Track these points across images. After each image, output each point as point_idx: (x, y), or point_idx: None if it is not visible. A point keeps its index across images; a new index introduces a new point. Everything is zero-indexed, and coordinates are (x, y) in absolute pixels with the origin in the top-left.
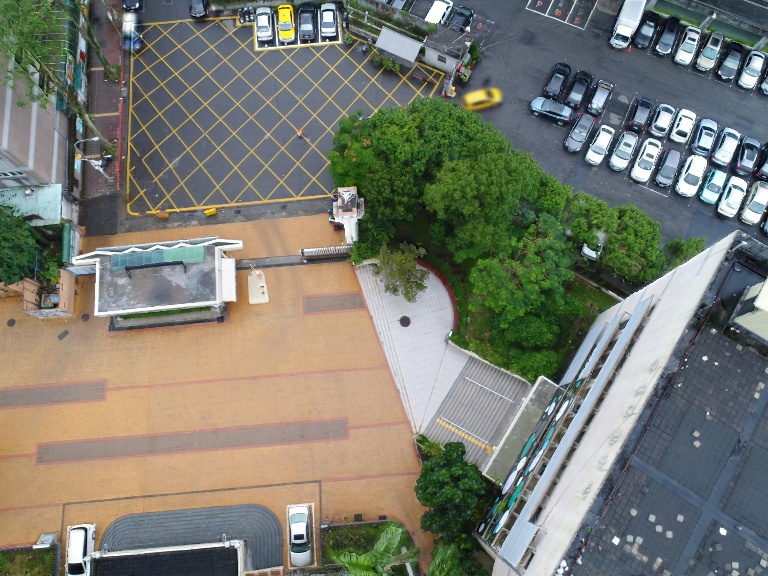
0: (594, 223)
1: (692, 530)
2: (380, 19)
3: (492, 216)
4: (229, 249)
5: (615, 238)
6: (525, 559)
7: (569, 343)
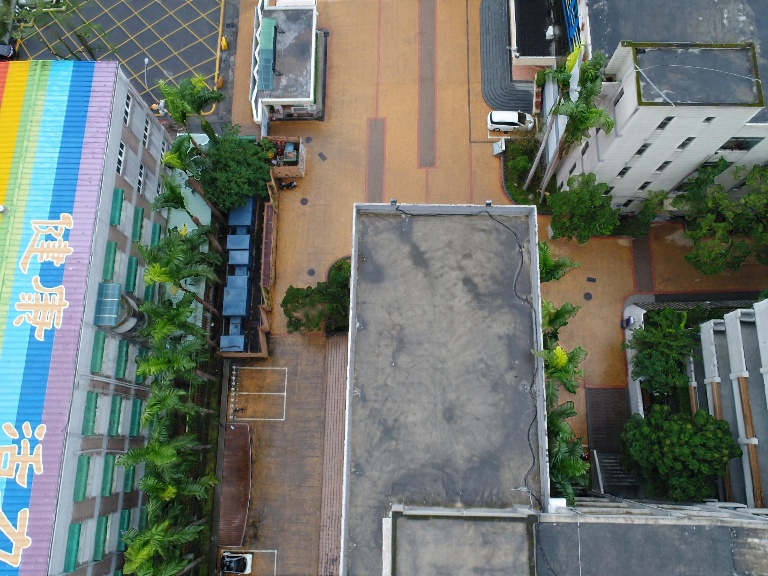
0: None
1: None
2: None
3: None
4: None
5: None
6: None
7: None
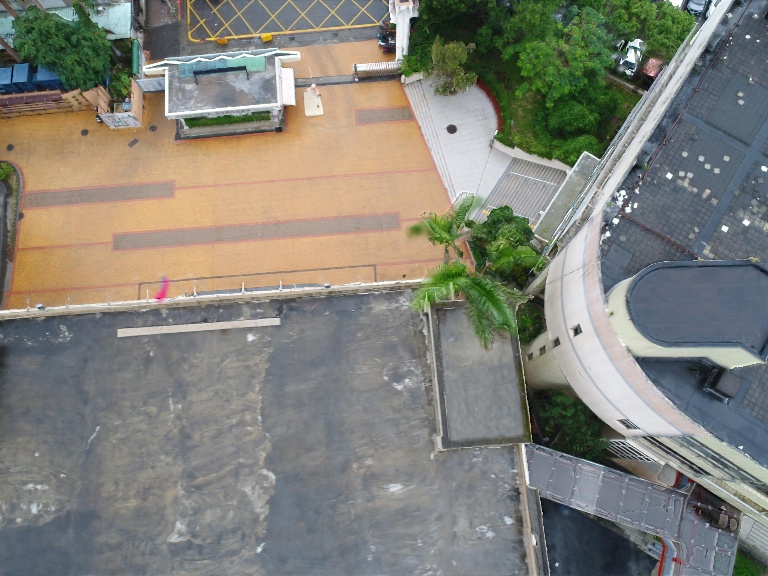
0: (634, 11)
1: (737, 168)
2: None
3: None
4: (288, 61)
5: (654, 25)
6: (584, 222)
7: (607, 139)
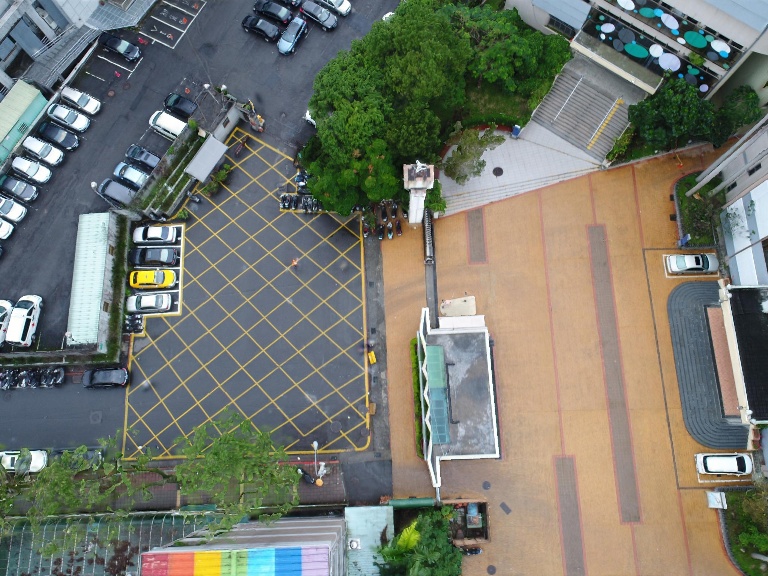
0: None
1: None
2: (166, 180)
3: (453, 40)
4: None
5: None
6: None
7: None
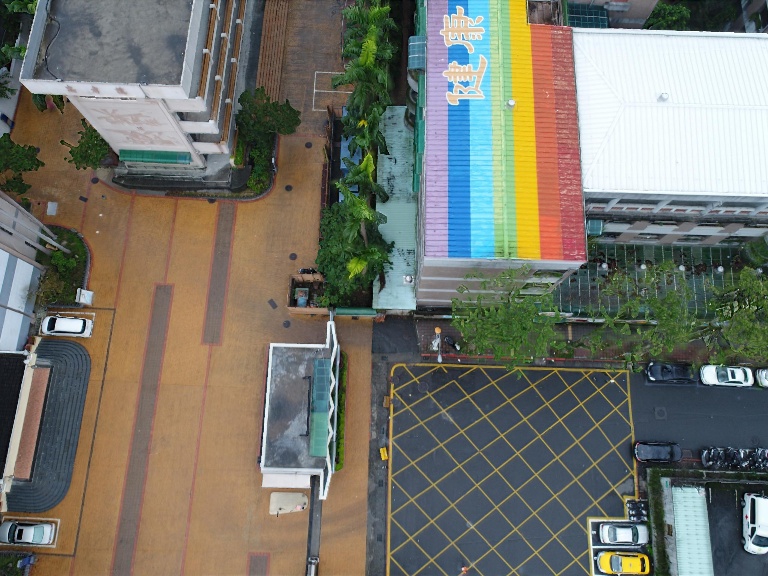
0: None
1: None
2: None
3: None
4: None
5: None
6: None
7: None
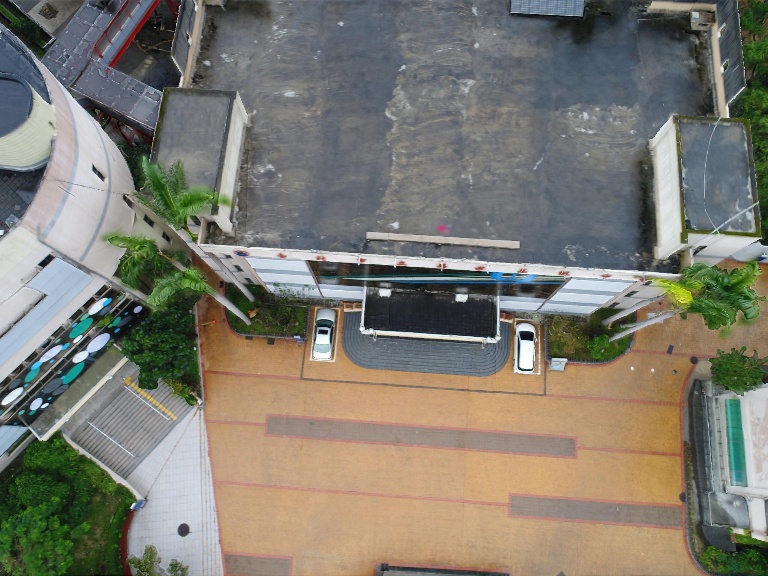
0: None
1: None
2: None
3: None
4: None
5: None
6: None
7: None
